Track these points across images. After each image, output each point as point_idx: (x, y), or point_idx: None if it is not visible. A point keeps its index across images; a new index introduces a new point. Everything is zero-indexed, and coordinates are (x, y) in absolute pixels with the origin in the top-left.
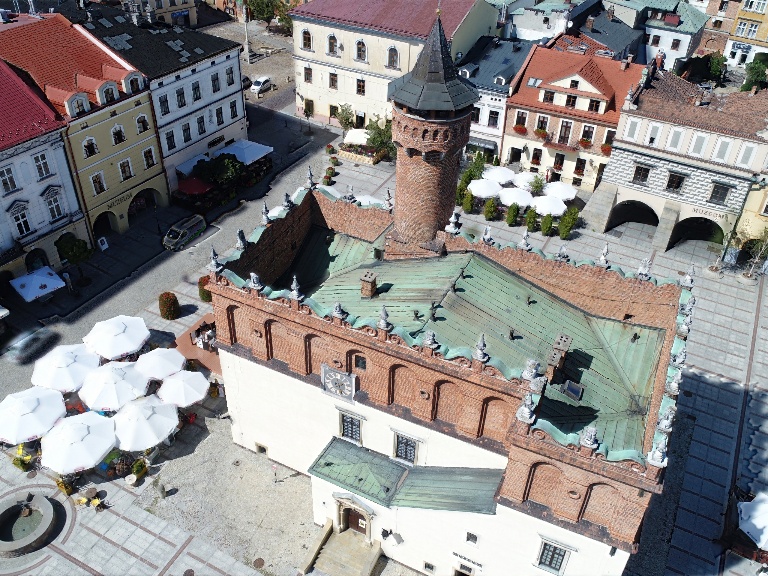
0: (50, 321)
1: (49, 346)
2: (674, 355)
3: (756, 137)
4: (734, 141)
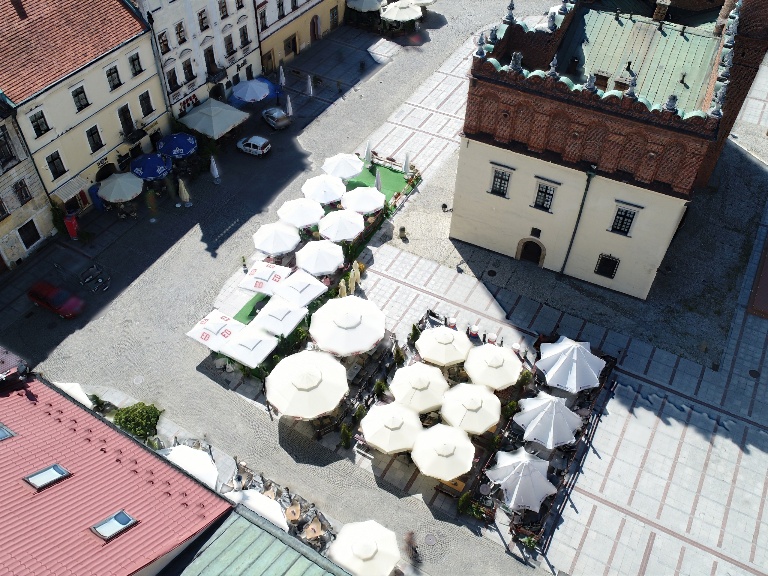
0: None
1: None
2: None
3: None
4: None
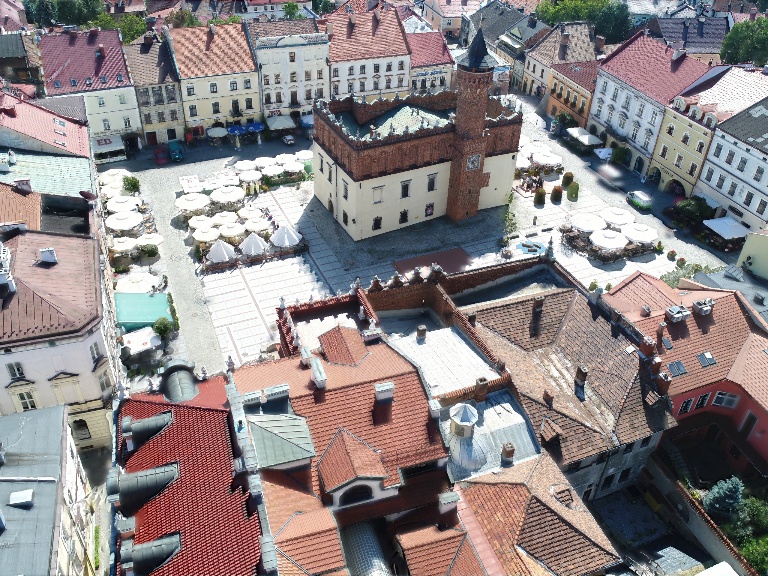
0: (588, 163)
1: (568, 160)
2: None
3: None
4: None
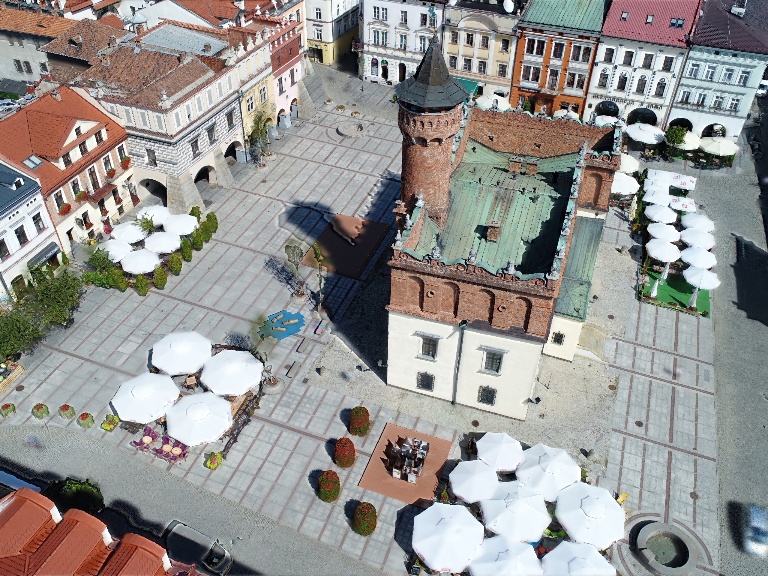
0: None
1: None
2: (537, 116)
3: (229, 67)
4: (222, 79)
